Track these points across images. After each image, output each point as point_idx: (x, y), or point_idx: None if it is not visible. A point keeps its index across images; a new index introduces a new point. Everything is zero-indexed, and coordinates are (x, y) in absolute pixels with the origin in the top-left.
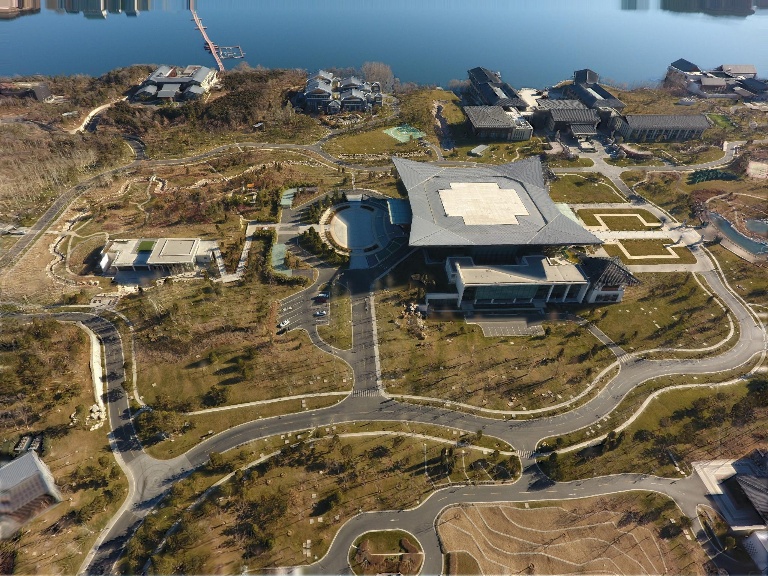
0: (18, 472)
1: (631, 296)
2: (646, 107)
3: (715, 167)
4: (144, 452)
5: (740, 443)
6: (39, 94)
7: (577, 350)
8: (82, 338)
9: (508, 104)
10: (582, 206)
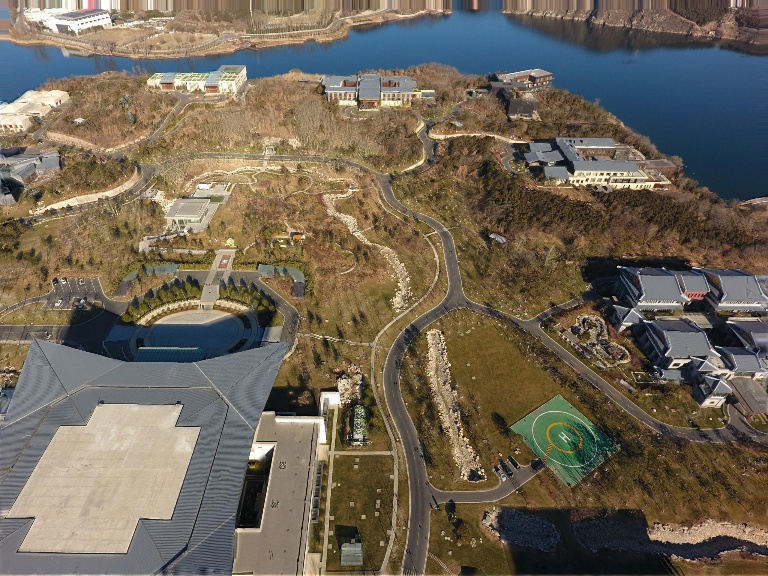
0: None
1: None
2: None
3: None
4: None
5: None
6: (514, 107)
7: None
8: None
9: None
10: None
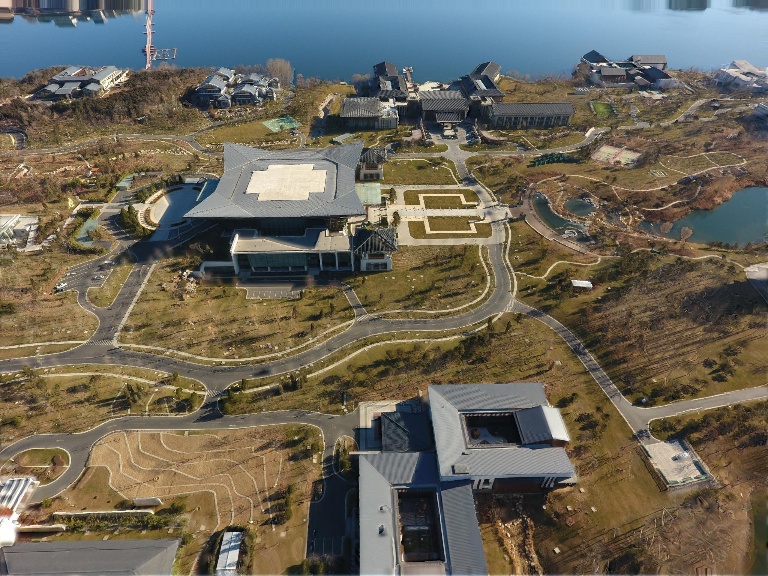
0: None
1: (405, 265)
2: (538, 97)
3: (566, 151)
4: None
5: (416, 387)
6: None
7: (320, 310)
8: None
9: (388, 95)
10: (412, 187)
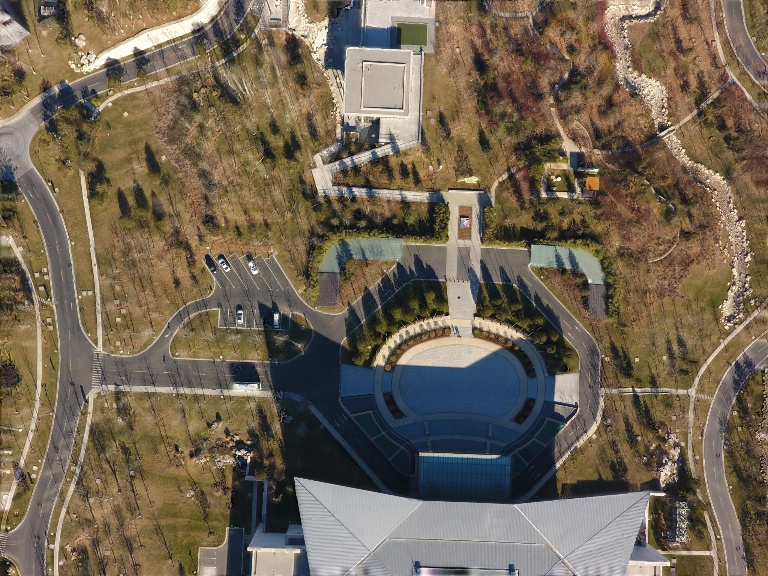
0: None
1: None
2: None
3: None
4: (41, 124)
5: None
6: None
7: None
8: (170, 6)
9: None
10: None
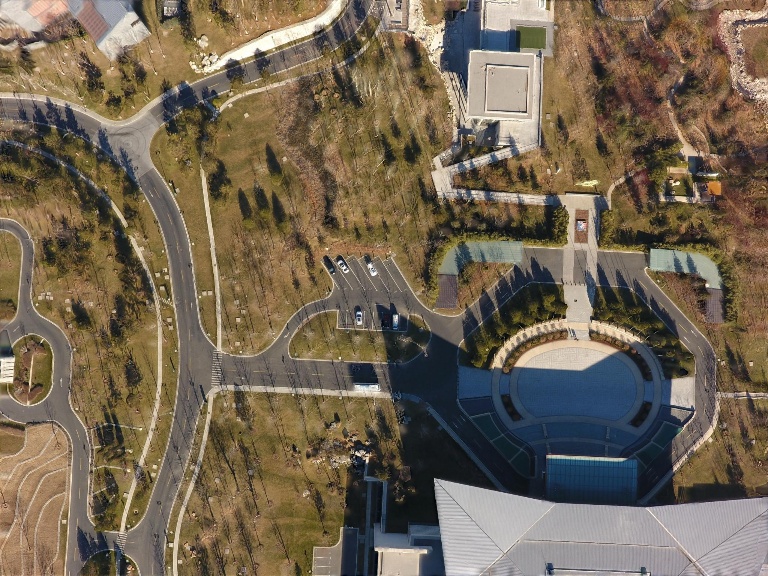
0: (110, 8)
1: None
2: None
3: None
4: (161, 125)
5: None
6: None
7: None
8: (299, 8)
9: None
10: None
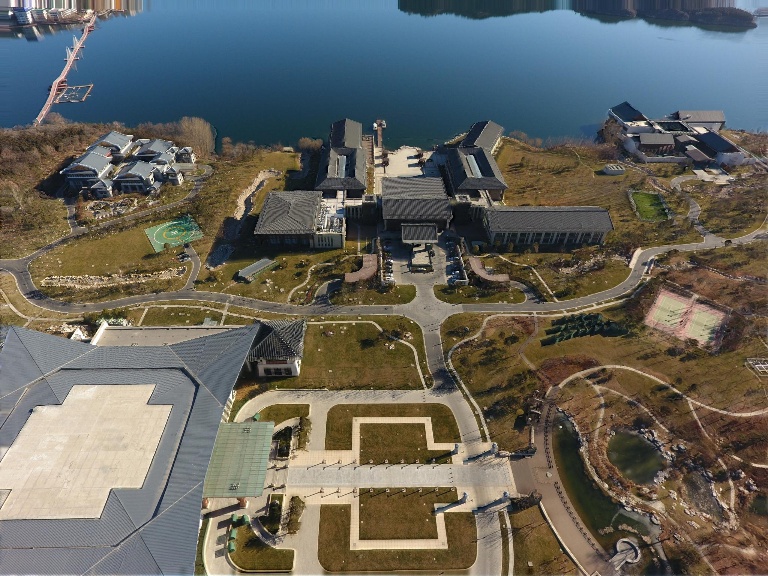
0: None
1: None
2: (554, 178)
3: (602, 304)
4: None
5: None
6: None
7: None
8: None
9: (336, 186)
10: (344, 397)
